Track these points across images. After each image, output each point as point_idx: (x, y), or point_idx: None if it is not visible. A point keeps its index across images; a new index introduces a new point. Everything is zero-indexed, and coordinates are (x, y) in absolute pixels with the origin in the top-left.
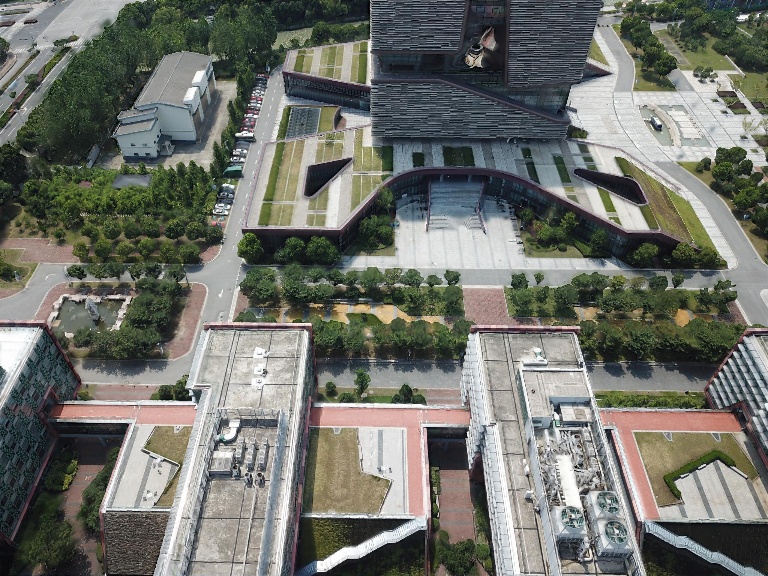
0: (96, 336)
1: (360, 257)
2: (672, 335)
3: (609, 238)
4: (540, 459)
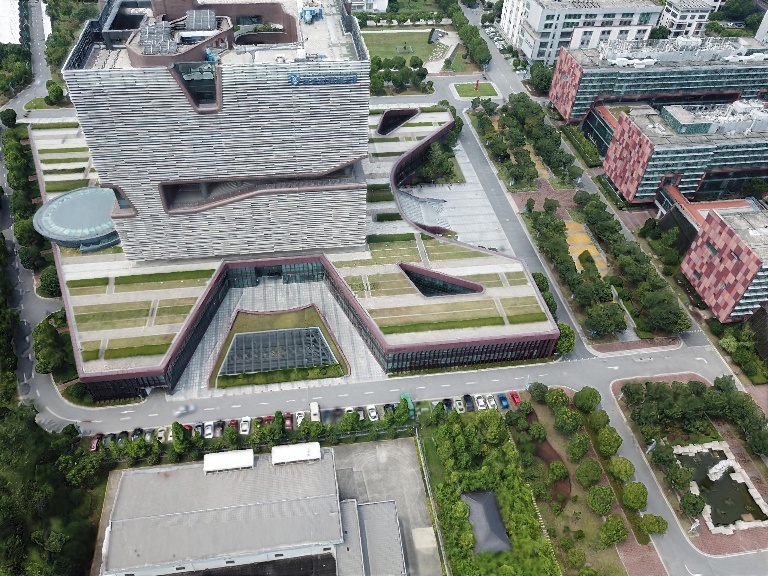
0: (762, 425)
1: None
2: (538, 121)
3: (445, 136)
4: (733, 121)
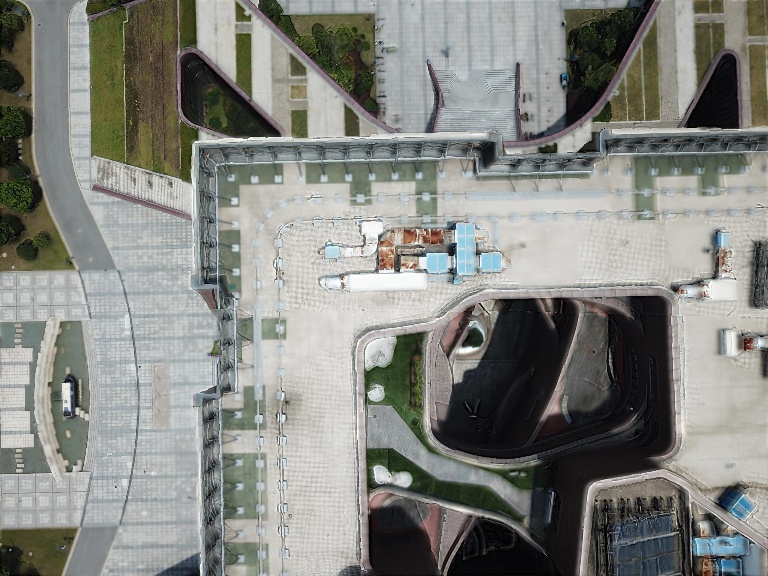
0: None
1: (616, 4)
2: None
3: None
4: None
